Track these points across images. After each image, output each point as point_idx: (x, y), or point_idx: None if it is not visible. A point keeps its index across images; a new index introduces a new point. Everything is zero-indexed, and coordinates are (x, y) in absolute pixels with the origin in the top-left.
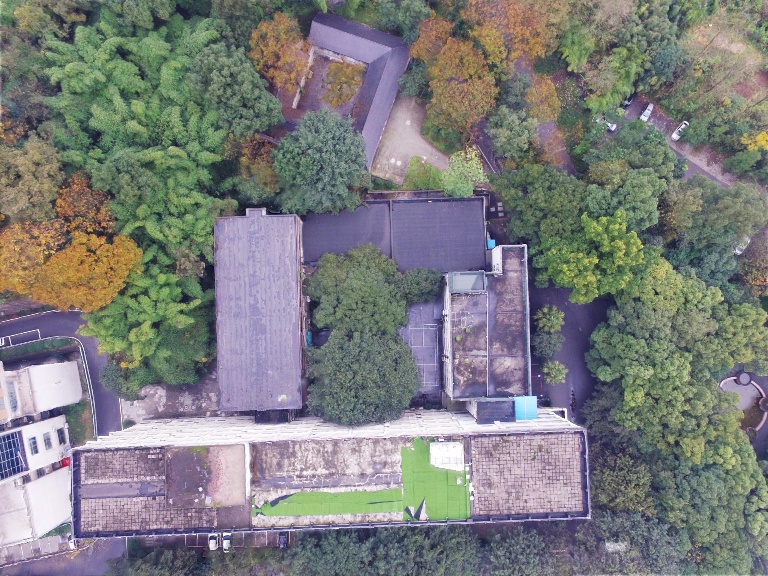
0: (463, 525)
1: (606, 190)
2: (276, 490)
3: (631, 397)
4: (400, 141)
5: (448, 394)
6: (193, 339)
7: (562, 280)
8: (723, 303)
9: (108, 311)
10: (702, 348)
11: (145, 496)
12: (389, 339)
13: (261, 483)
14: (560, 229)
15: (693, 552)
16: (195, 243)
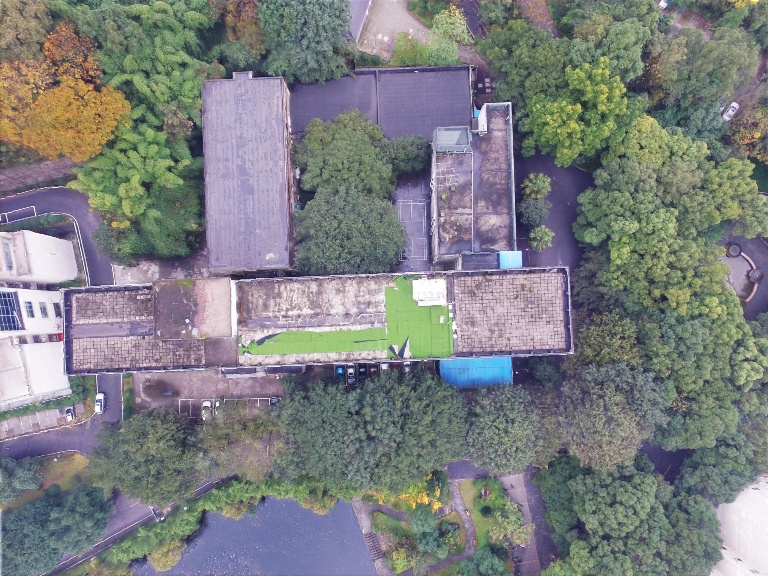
0: (450, 383)
1: (590, 41)
2: (262, 330)
3: (617, 254)
4: (387, 17)
5: (435, 259)
6: (183, 209)
7: (546, 133)
8: (710, 161)
9: (98, 163)
10: (688, 201)
11: (135, 335)
12: (375, 197)
13: (247, 323)
14: (544, 84)
15: (679, 402)
16: (183, 106)
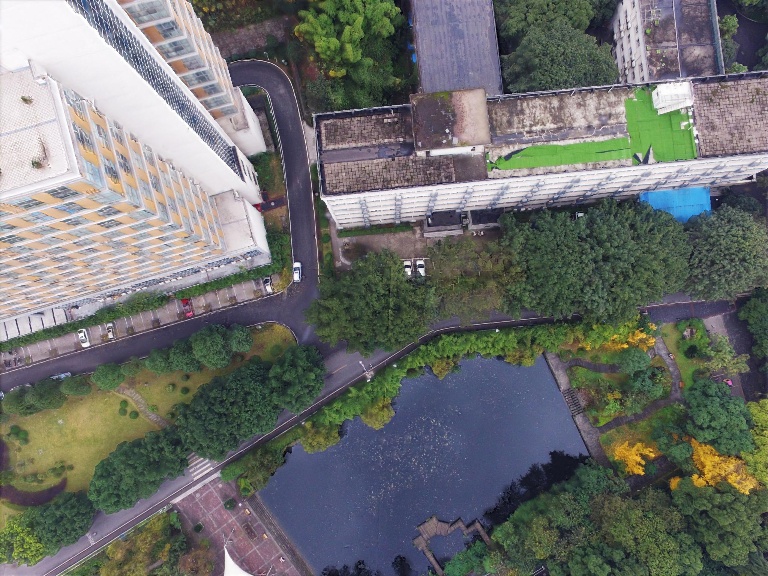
0: None
1: None
2: (508, 146)
3: None
4: None
5: None
6: (382, 69)
7: None
8: None
9: (326, 4)
10: None
11: (384, 158)
12: (583, 34)
13: (493, 140)
14: None
15: None
16: None
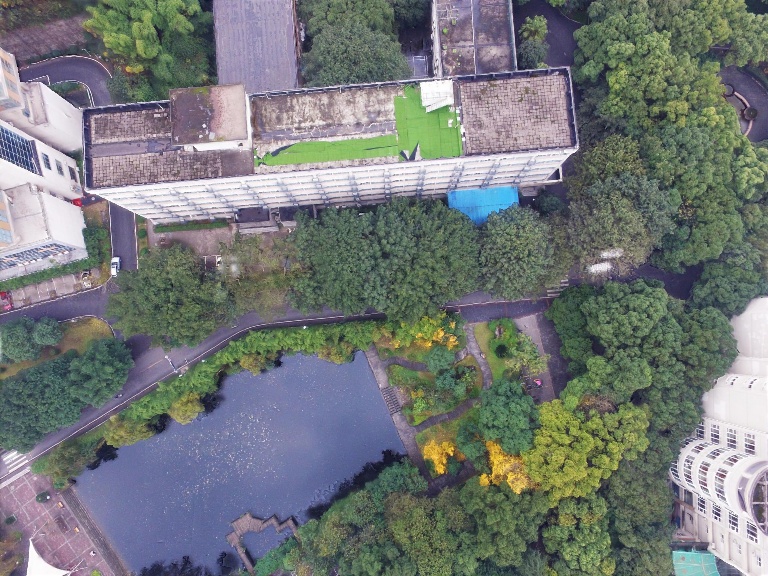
0: (460, 211)
1: None
2: (276, 142)
3: (615, 79)
4: None
5: None
6: (194, 66)
7: None
8: None
9: (112, 1)
10: (679, 20)
11: (152, 152)
12: (379, 33)
13: (262, 136)
14: None
15: (684, 209)
16: None
